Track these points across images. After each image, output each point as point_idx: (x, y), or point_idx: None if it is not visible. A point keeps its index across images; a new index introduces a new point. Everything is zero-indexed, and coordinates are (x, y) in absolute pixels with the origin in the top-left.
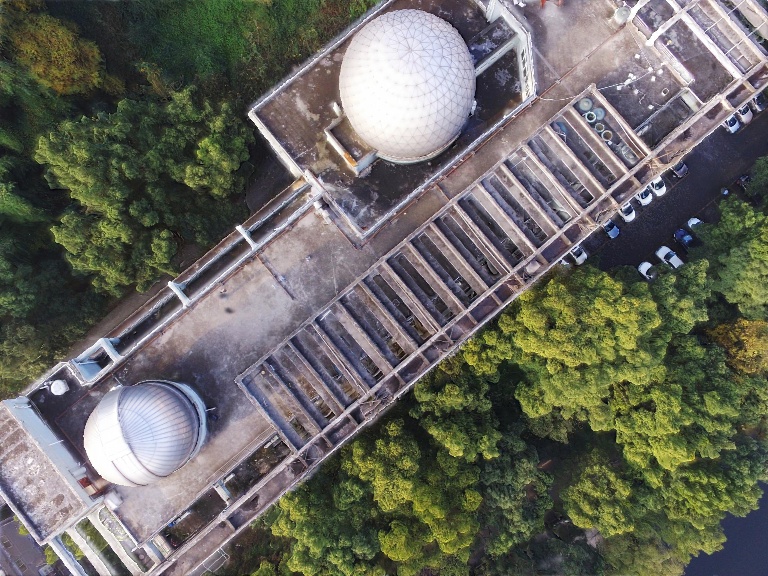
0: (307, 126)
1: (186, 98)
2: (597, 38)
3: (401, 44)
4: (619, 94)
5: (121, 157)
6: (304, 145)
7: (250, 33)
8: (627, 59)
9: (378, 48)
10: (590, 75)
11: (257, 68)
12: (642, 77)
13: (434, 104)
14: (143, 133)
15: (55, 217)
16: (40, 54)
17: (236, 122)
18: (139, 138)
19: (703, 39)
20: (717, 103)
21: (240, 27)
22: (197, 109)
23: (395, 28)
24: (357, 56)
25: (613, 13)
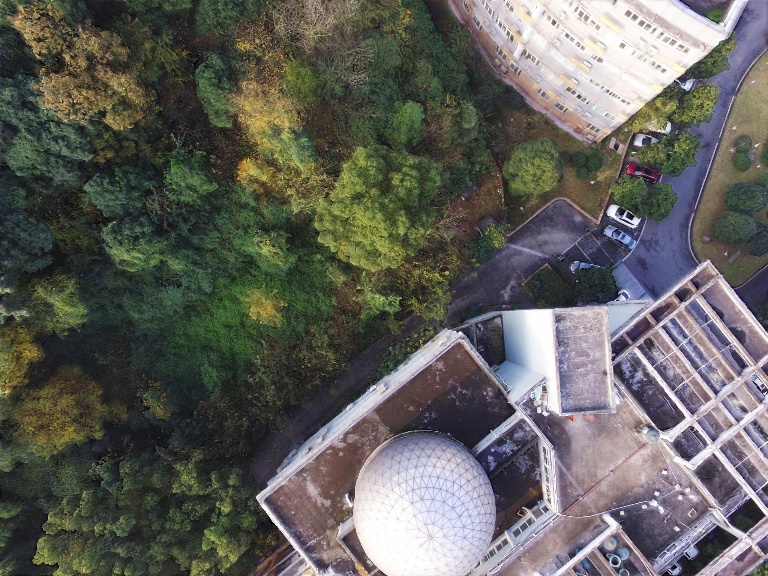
0: (317, 512)
1: (191, 480)
2: (623, 450)
3: (421, 531)
4: (644, 512)
5: (123, 558)
6: (314, 533)
7: (258, 358)
8: (653, 474)
9: (396, 527)
10: (614, 491)
11: (265, 393)
12: (668, 494)
13: (453, 575)
14: (146, 519)
15: (54, 569)
16: (38, 427)
17: (243, 494)
18: (142, 525)
19: (734, 475)
20: (746, 547)
21: (247, 328)
22: (202, 482)
23: (414, 508)
24: (373, 520)
25: (640, 423)
